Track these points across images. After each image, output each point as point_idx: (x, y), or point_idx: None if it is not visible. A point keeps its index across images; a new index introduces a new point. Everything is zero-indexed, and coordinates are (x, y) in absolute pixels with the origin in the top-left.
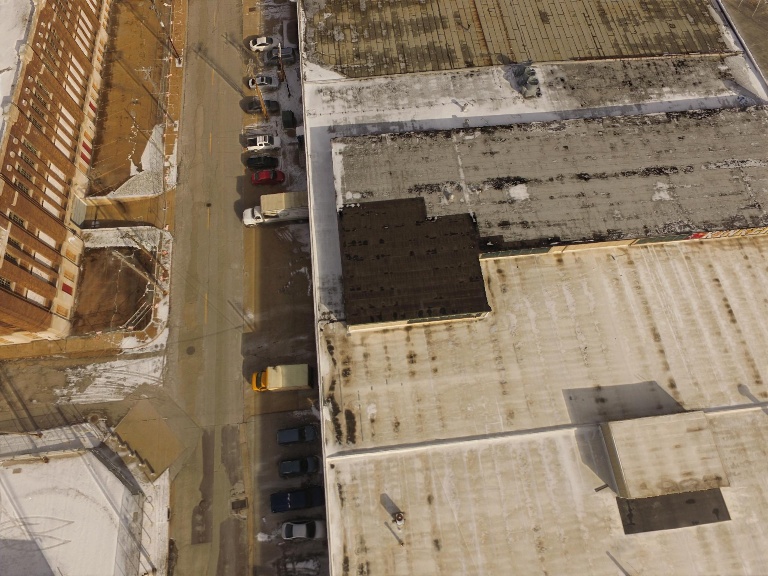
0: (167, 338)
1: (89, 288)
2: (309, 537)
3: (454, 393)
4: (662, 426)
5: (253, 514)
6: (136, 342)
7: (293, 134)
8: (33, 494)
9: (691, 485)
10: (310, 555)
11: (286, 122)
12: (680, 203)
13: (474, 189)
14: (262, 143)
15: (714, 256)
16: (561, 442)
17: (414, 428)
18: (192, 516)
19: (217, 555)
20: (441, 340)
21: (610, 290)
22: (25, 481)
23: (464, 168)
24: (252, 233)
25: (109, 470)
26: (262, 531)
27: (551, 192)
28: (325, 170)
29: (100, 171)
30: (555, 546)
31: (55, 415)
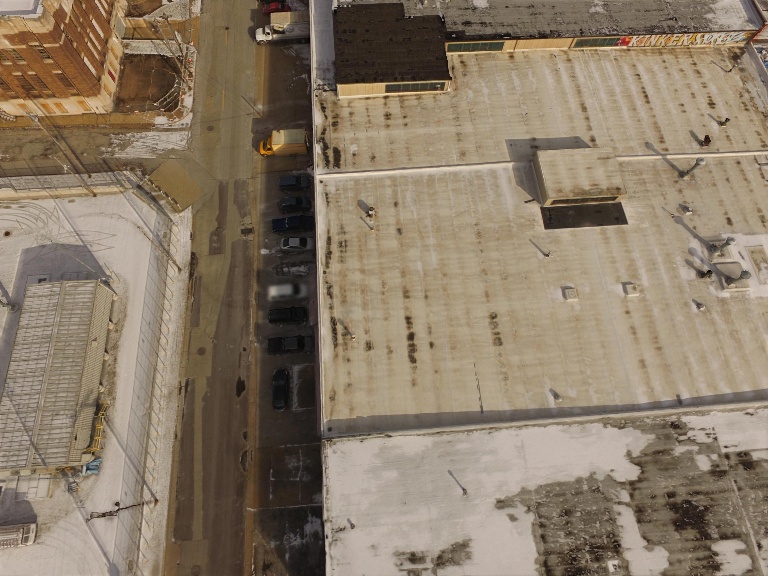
0: (191, 119)
1: (128, 81)
2: (302, 246)
3: (419, 139)
4: (579, 155)
5: (258, 237)
6: (166, 120)
7: None
8: (84, 216)
9: (597, 192)
10: (302, 262)
11: None
12: (611, 15)
13: None
14: None
15: (638, 59)
16: (501, 172)
17: (386, 160)
18: (210, 237)
19: (229, 262)
20: (412, 105)
21: (550, 77)
22: (78, 208)
23: None
24: (262, 49)
25: None
26: (265, 248)
27: (507, 3)
28: None
29: None
30: (490, 235)
31: (102, 164)
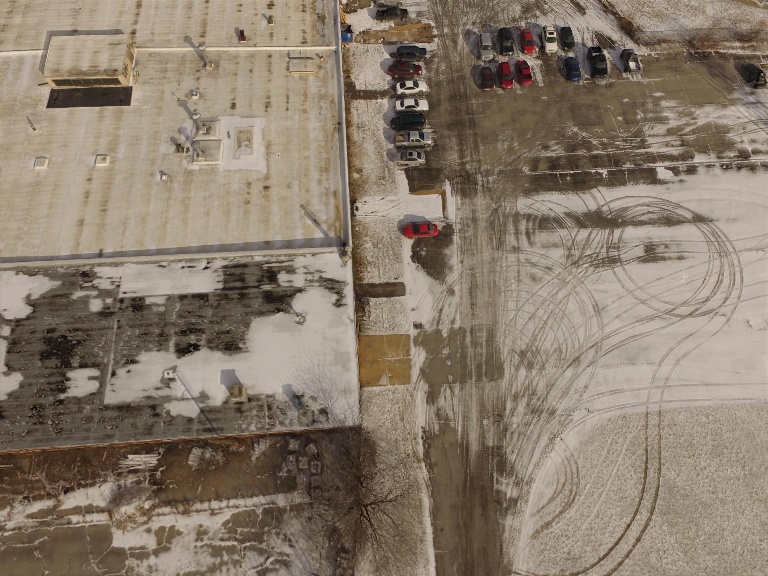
0: None
1: None
2: None
3: None
4: (91, 40)
5: None
6: None
7: None
8: None
9: (93, 72)
10: None
11: None
12: None
13: None
14: None
15: None
16: (29, 59)
17: None
18: None
19: None
20: None
21: None
22: None
23: None
24: None
25: None
26: None
27: None
28: None
29: None
30: None
31: None
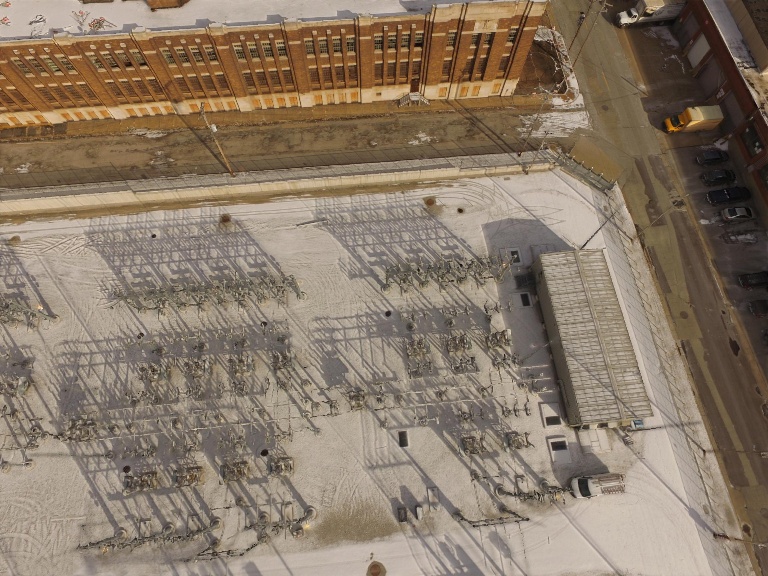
0: (583, 100)
1: None
2: (749, 215)
3: None
4: None
5: (692, 209)
6: (562, 101)
7: None
8: (526, 192)
9: None
10: (747, 231)
11: None
12: None
13: None
14: None
15: None
16: None
17: None
18: (646, 210)
19: (674, 232)
20: None
21: None
22: (516, 185)
23: None
24: (623, 32)
25: (588, 172)
26: (703, 218)
27: None
28: None
29: None
30: None
31: None
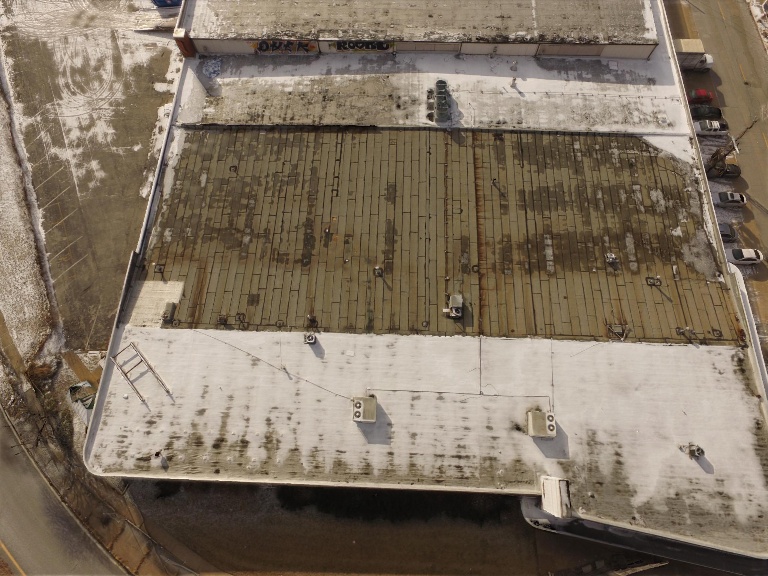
0: None
1: None
2: None
3: None
4: None
5: None
6: None
7: None
8: None
9: None
10: None
11: None
12: None
13: None
14: (713, 121)
15: None
16: None
17: None
18: None
19: None
20: None
21: None
22: None
23: (531, 7)
24: None
25: None
26: None
27: None
28: None
29: None
30: None
31: None
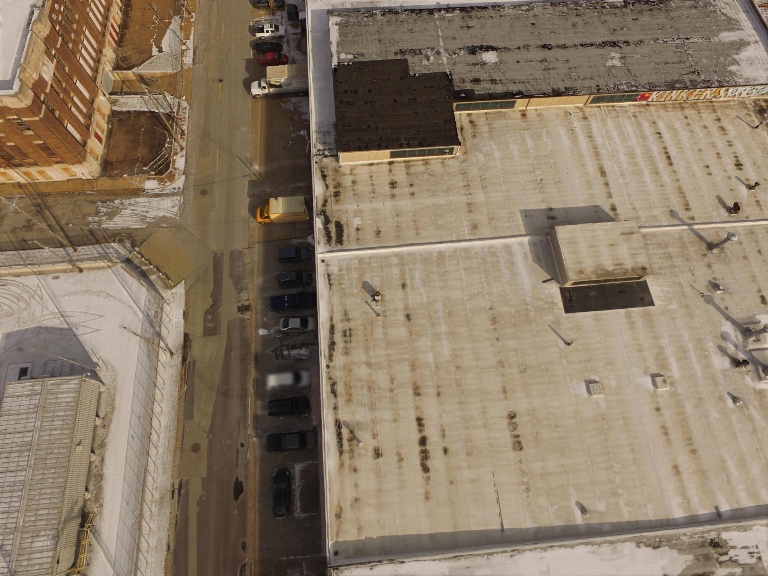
0: (183, 183)
1: (116, 141)
2: (302, 328)
3: (427, 210)
4: (600, 230)
5: (255, 315)
6: (157, 184)
7: (296, 26)
8: (70, 295)
9: (621, 272)
10: (303, 344)
11: (290, 14)
12: (629, 69)
13: (451, 53)
14: (269, 30)
15: (658, 115)
16: (516, 247)
17: (393, 235)
18: (204, 316)
19: (225, 344)
20: (418, 172)
21: (565, 138)
22: (63, 285)
23: (443, 38)
24: (258, 103)
25: (135, 273)
26: (263, 327)
27: (518, 57)
28: (323, 43)
29: (126, 50)
30: (506, 320)
31: (88, 236)
